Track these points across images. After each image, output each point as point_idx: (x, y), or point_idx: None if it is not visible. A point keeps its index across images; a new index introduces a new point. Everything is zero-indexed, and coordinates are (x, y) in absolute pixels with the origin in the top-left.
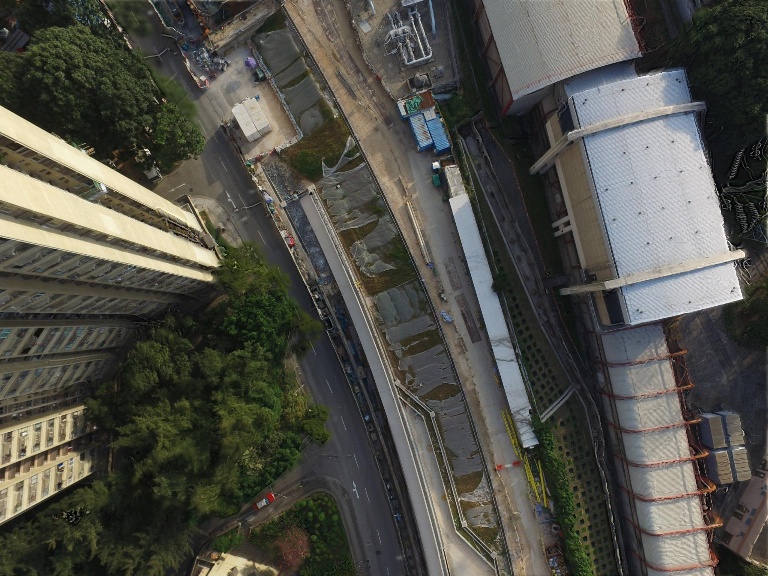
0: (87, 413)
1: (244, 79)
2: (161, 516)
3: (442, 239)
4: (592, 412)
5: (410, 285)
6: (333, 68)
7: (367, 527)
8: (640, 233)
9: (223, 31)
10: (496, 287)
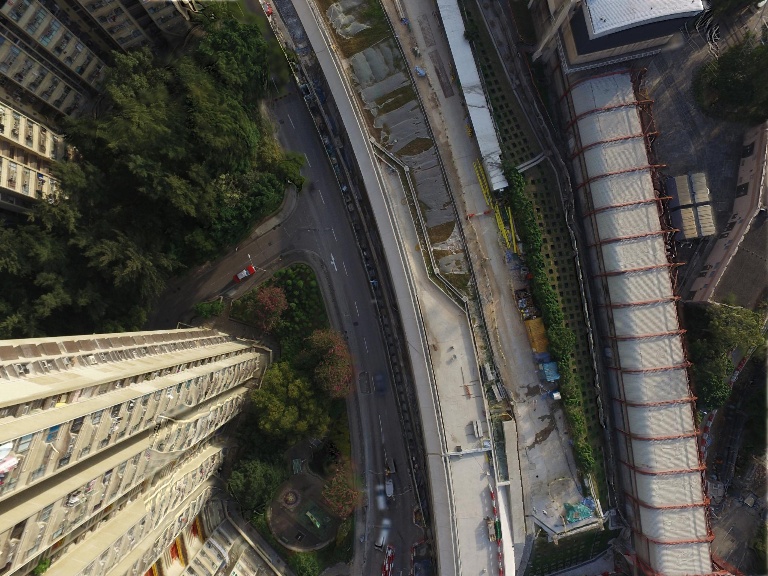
0: (67, 139)
1: None
2: (140, 229)
3: None
4: (563, 179)
5: (385, 43)
6: None
7: (345, 299)
8: None
9: None
10: (468, 34)
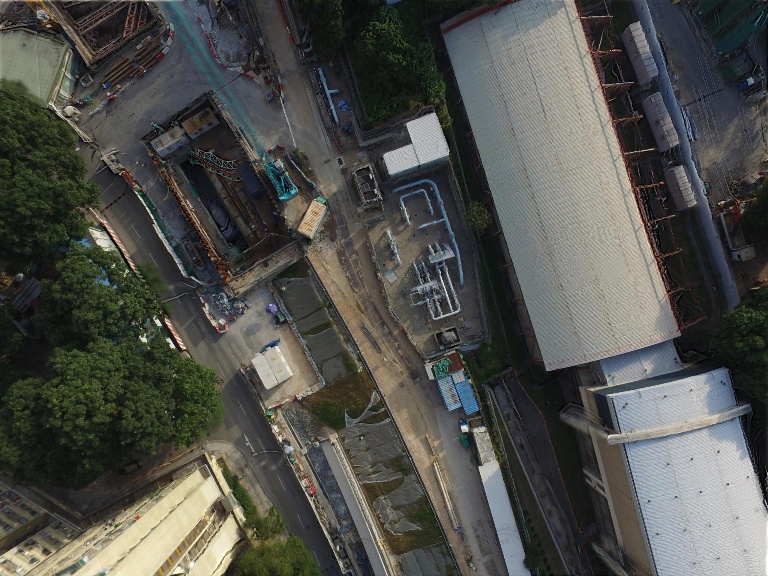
0: None
1: (264, 321)
2: None
3: (470, 501)
4: None
5: (437, 548)
6: (357, 320)
7: None
8: (686, 554)
9: (244, 278)
10: (528, 564)
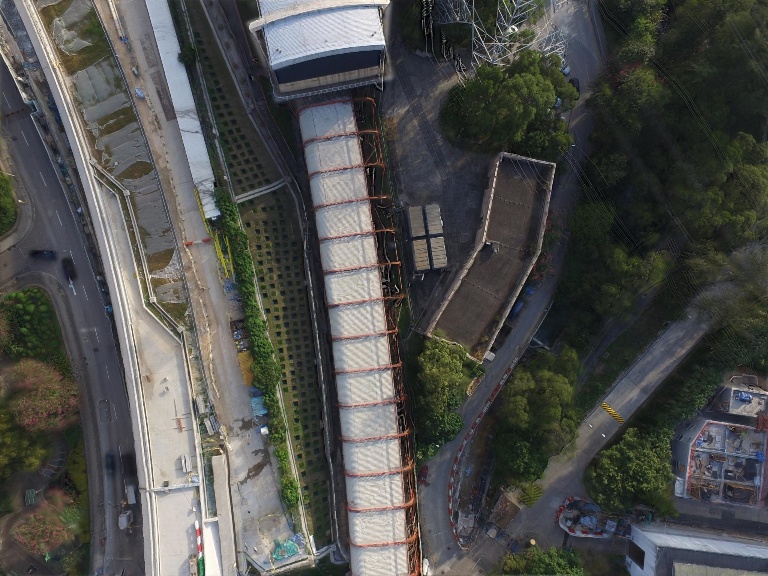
0: None
1: None
2: None
3: (138, 15)
4: None
5: (106, 62)
6: None
7: (84, 324)
8: None
9: None
10: (180, 56)
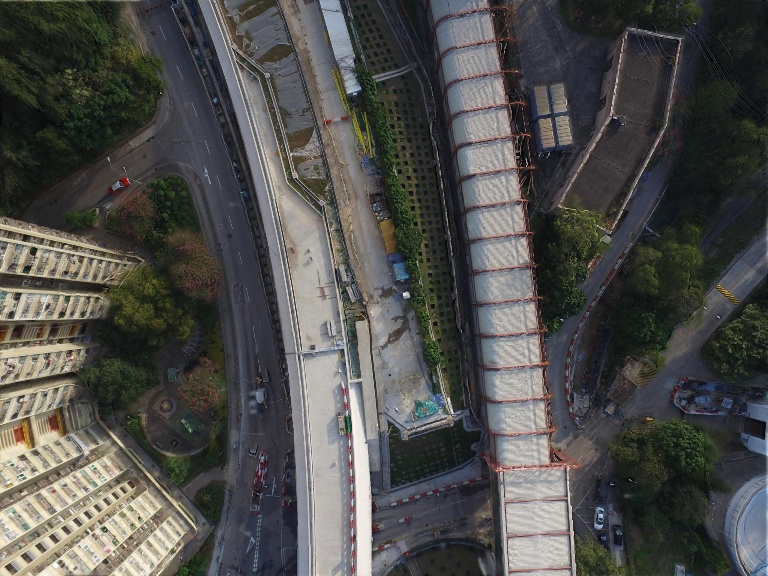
0: None
1: None
2: None
3: None
4: (429, 91)
5: None
6: None
7: (219, 212)
8: None
9: None
10: None
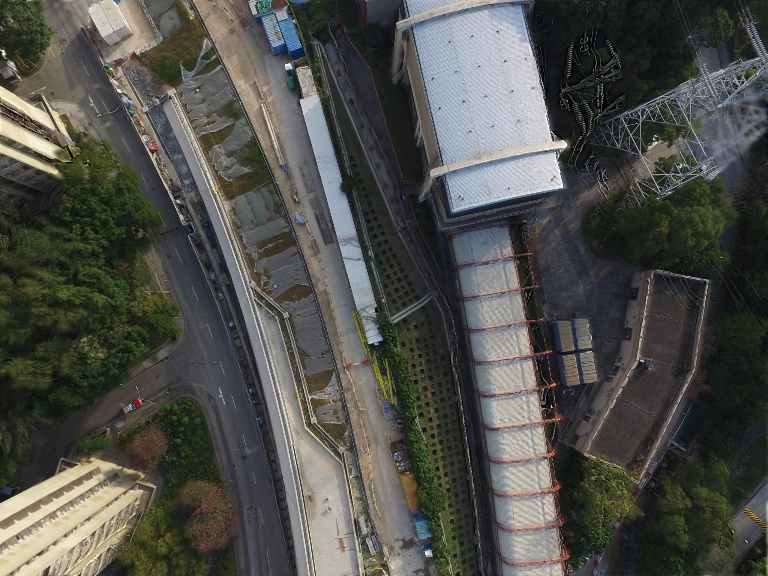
0: None
1: None
2: None
3: (297, 142)
4: (450, 319)
5: (265, 188)
6: None
7: (233, 433)
8: (462, 120)
9: None
10: (344, 187)
